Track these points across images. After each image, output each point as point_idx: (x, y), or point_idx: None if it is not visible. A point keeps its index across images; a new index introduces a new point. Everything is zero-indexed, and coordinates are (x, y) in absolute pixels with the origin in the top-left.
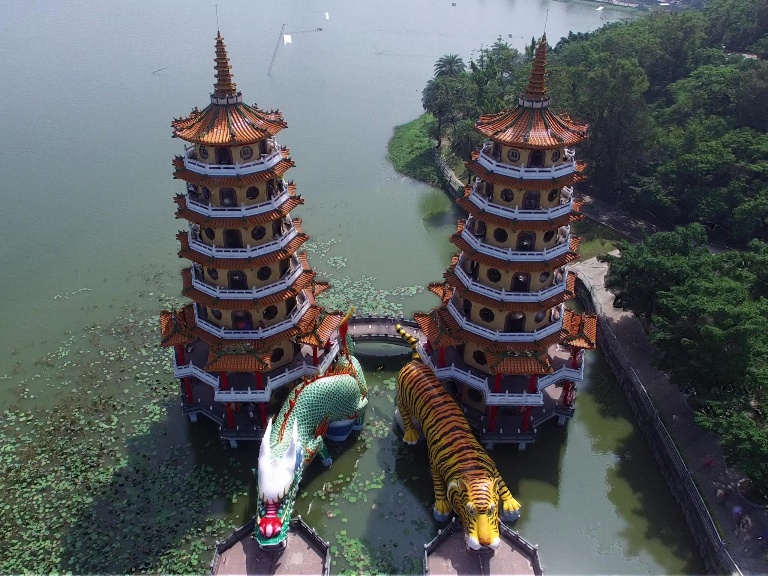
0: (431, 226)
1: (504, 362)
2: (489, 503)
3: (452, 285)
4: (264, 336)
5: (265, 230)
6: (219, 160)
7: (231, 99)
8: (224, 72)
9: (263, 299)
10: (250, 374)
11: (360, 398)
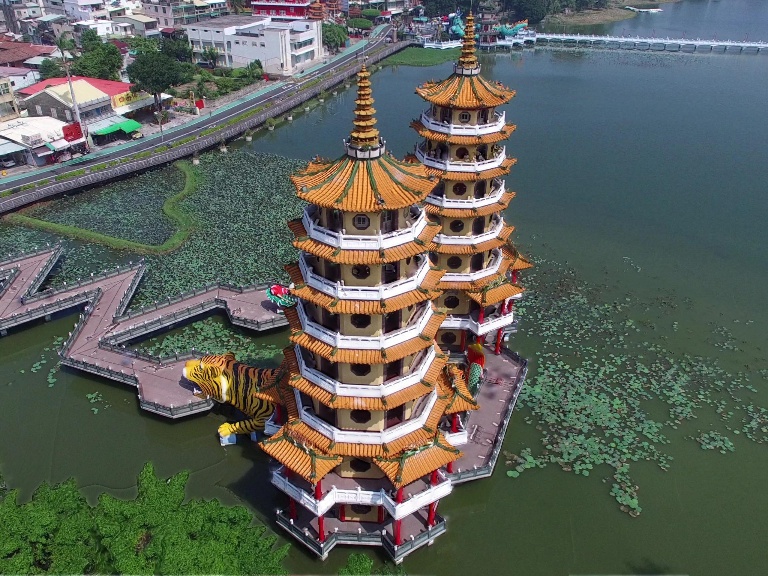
0: None
1: None
2: None
3: (443, 377)
4: None
5: None
6: None
7: None
8: None
9: None
10: None
11: None
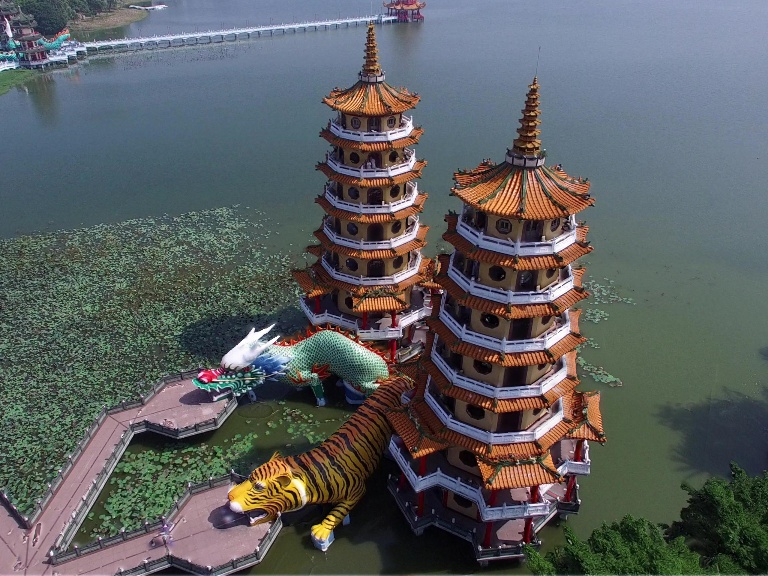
0: (759, 353)
1: (401, 415)
2: (260, 479)
3: None
4: (336, 277)
5: (360, 193)
6: (343, 122)
7: (365, 77)
8: (368, 54)
9: (338, 246)
10: (314, 297)
11: (374, 380)
